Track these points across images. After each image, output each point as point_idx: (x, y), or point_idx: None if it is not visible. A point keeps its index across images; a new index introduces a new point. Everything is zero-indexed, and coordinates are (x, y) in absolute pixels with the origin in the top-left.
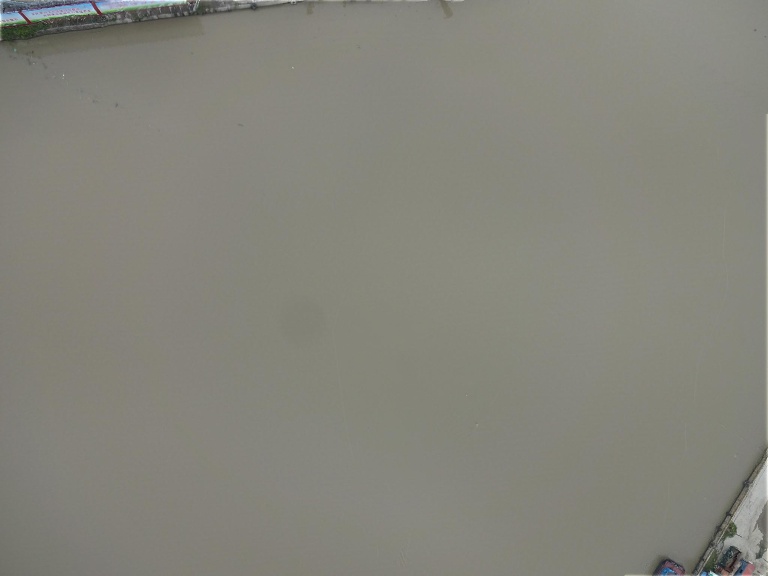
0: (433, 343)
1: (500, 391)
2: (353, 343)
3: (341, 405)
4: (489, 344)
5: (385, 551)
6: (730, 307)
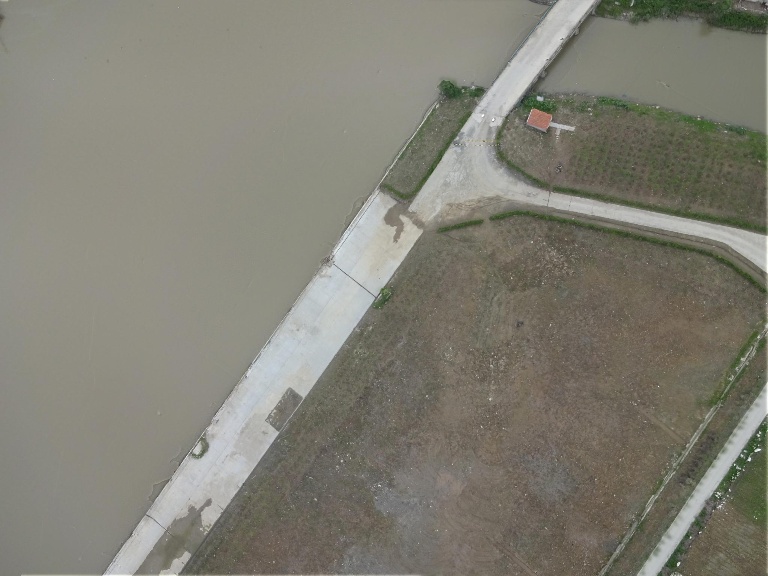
0: None
1: None
2: None
3: None
4: None
5: None
6: (89, 409)
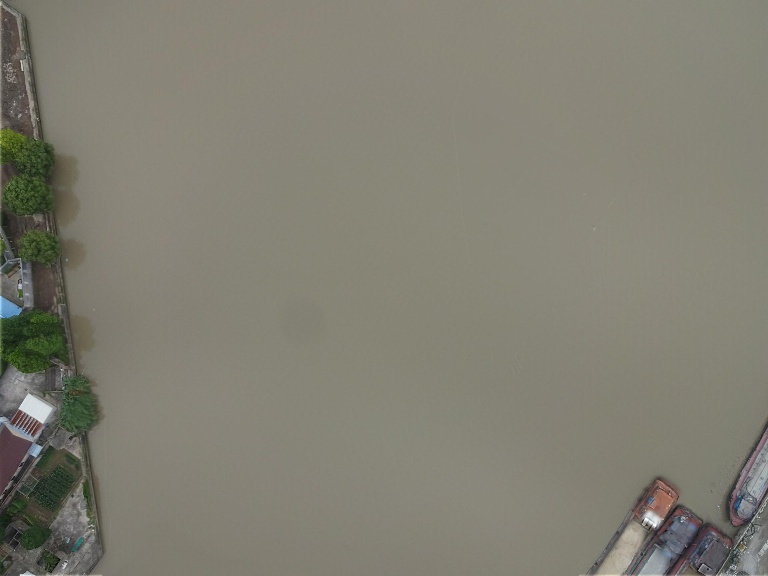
0: (551, 132)
1: (618, 193)
2: (472, 127)
3: (458, 197)
4: (608, 140)
5: (500, 358)
6: None
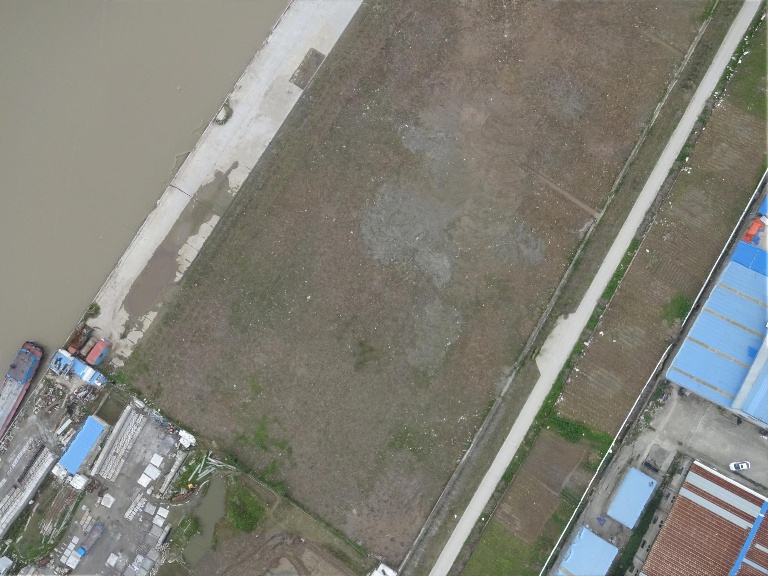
0: None
1: None
2: None
3: None
4: None
5: None
6: (104, 92)
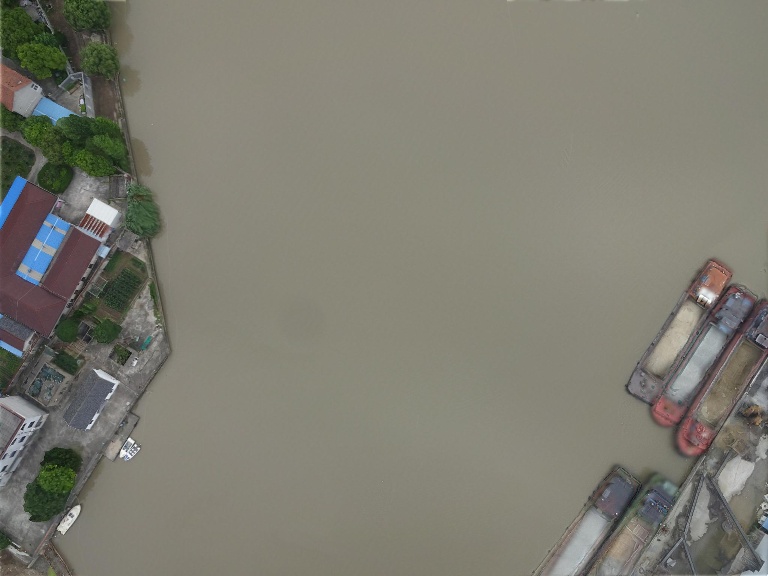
0: None
1: None
2: None
3: None
4: None
5: (548, 152)
6: None
